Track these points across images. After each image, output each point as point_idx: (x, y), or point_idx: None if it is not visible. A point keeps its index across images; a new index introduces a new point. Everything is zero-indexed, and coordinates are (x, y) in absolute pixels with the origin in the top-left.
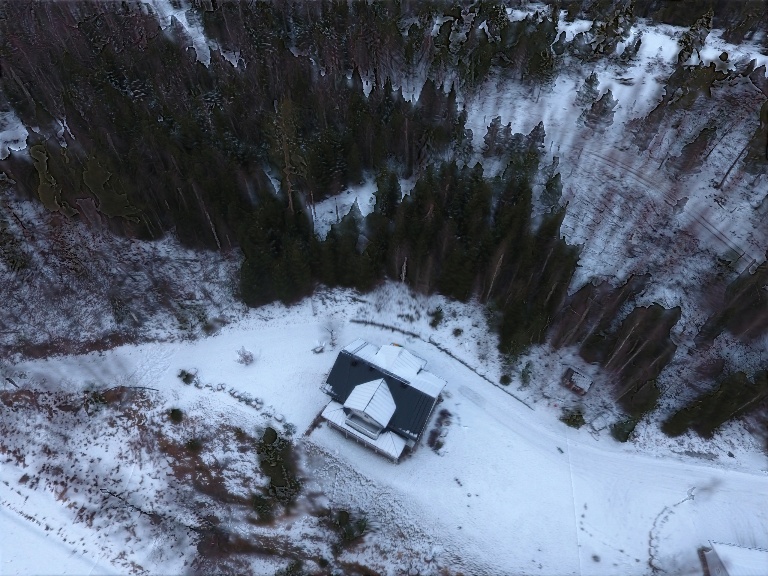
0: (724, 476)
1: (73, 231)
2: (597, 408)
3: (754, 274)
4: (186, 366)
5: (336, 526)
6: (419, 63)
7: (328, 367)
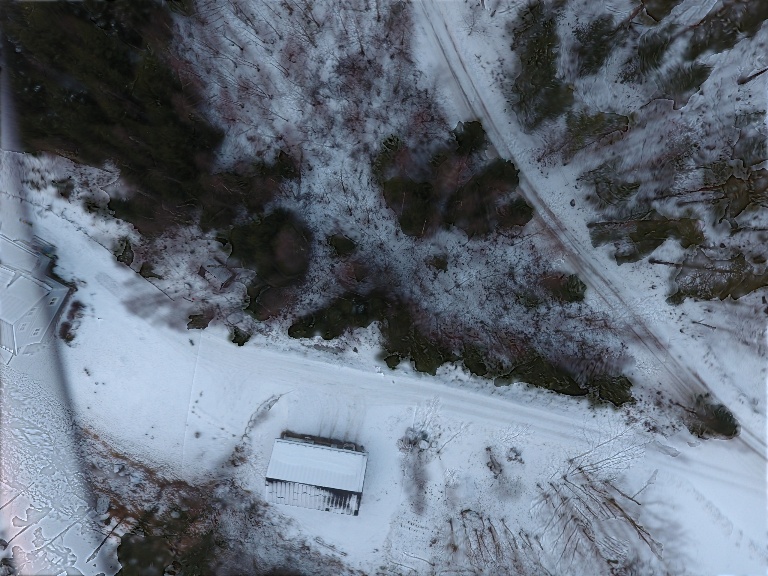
0: (337, 371)
1: None
2: (237, 302)
3: (395, 185)
4: None
5: (0, 392)
6: None
7: None
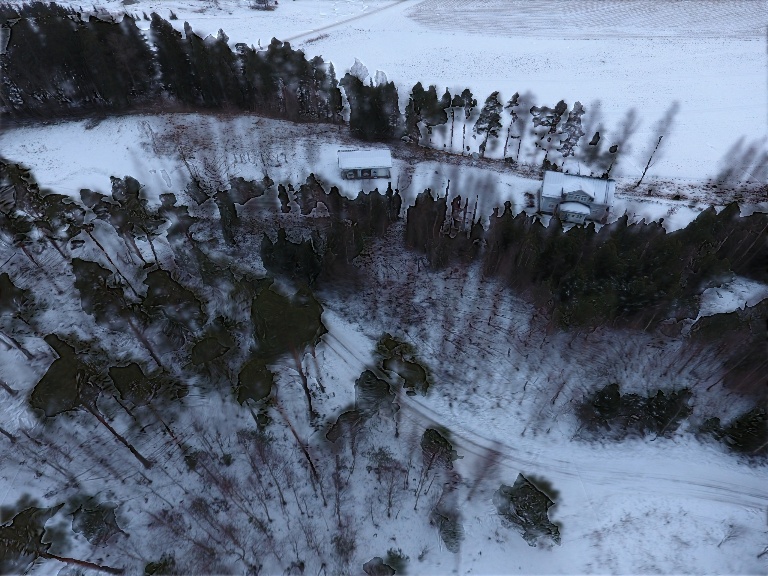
0: None
1: None
2: None
3: None
4: None
5: None
6: None
7: None
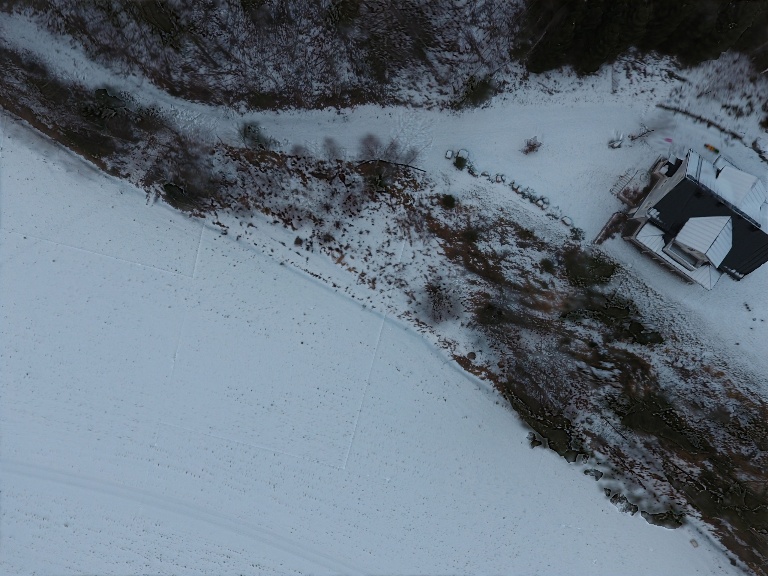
0: None
1: None
2: None
3: None
4: (453, 145)
5: (610, 321)
6: None
7: (625, 168)
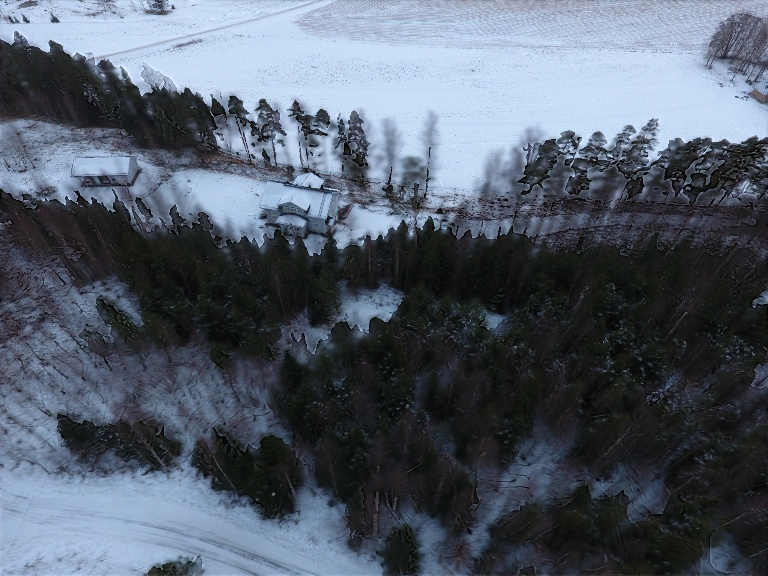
0: None
1: None
2: None
3: None
4: (453, 228)
5: None
6: None
7: None
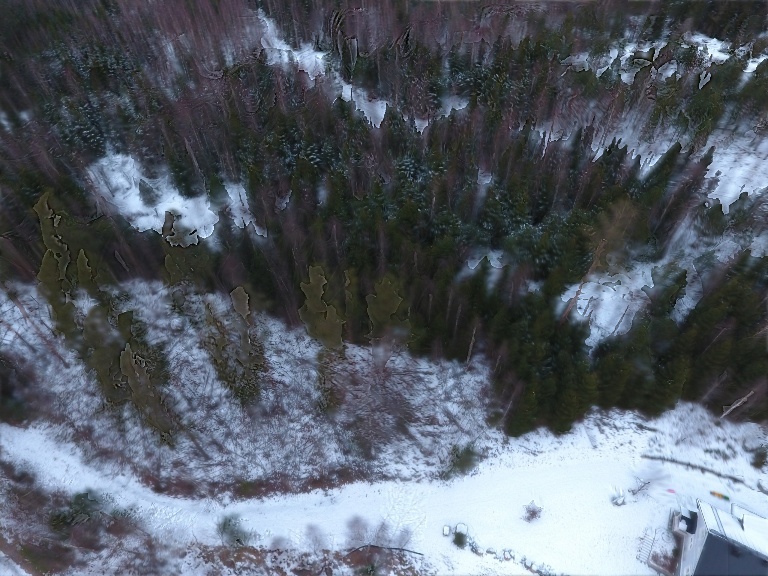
0: None
1: (271, 332)
2: None
3: None
4: (449, 519)
5: None
6: (627, 116)
7: (641, 528)
